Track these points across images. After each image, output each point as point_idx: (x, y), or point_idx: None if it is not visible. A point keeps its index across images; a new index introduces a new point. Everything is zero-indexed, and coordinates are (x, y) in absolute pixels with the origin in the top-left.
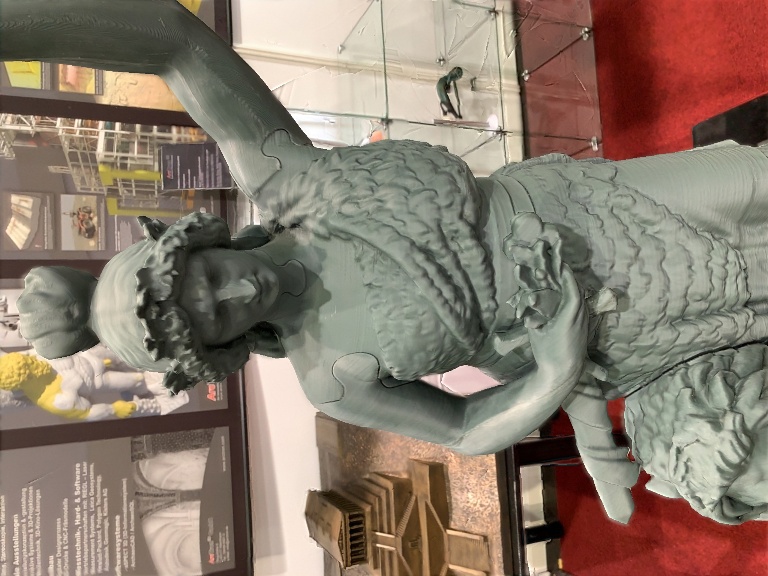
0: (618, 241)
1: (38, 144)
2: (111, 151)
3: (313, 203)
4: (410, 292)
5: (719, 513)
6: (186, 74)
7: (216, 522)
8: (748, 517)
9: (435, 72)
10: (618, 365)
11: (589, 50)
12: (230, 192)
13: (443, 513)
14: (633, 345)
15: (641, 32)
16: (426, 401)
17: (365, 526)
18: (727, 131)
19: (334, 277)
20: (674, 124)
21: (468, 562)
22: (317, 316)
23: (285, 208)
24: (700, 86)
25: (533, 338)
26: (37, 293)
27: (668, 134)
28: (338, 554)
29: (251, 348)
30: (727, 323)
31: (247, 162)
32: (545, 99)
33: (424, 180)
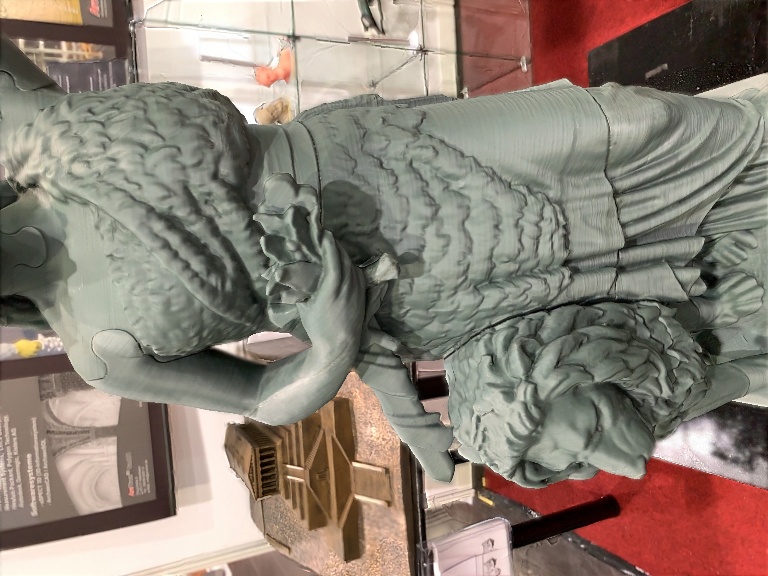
0: (413, 199)
1: None
2: None
3: (41, 161)
4: (155, 264)
5: (520, 479)
6: None
7: (134, 456)
8: (556, 479)
9: None
10: (419, 332)
11: None
12: None
13: (349, 446)
14: (432, 311)
15: None
16: (210, 374)
17: (276, 459)
18: (619, 59)
19: (77, 246)
20: None
21: (372, 492)
22: (66, 288)
23: (17, 165)
24: (626, 3)
25: (301, 312)
26: None
27: None
28: (249, 486)
29: (3, 323)
30: (537, 285)
31: None
32: (481, 13)
33: (165, 135)
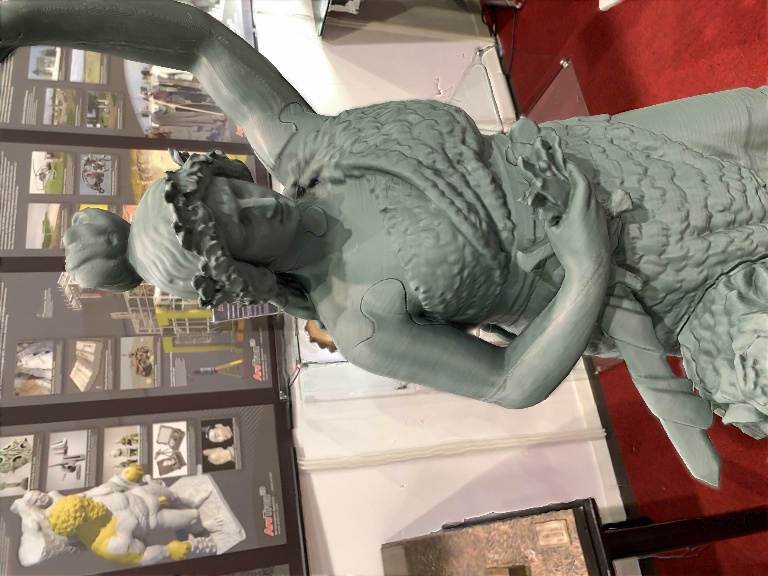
0: (623, 162)
1: (102, 295)
2: (167, 295)
3: (327, 152)
4: (424, 207)
5: None
6: (211, 59)
7: None
8: None
9: None
10: (654, 282)
11: None
12: (277, 322)
13: None
14: (664, 258)
15: None
16: (461, 339)
17: None
18: None
19: (353, 215)
20: None
21: None
22: (341, 256)
23: (304, 167)
24: None
25: (553, 238)
26: None
27: None
28: None
29: (282, 302)
30: (759, 230)
31: (267, 131)
32: None
33: (424, 115)
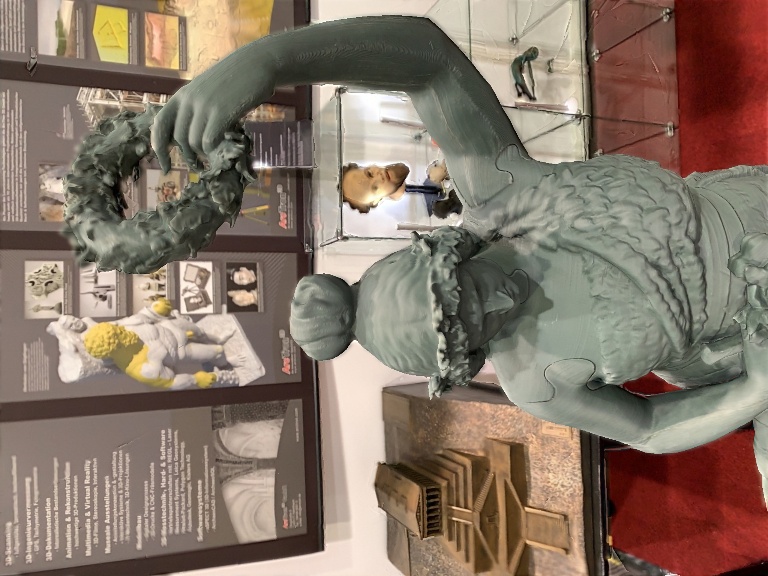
0: None
1: None
2: None
3: (544, 217)
4: (638, 305)
5: None
6: (441, 93)
7: (289, 490)
8: None
9: (507, 51)
10: None
11: (669, 32)
12: (306, 170)
13: (522, 491)
14: None
15: (729, 16)
16: (623, 403)
17: (441, 500)
18: None
19: (557, 287)
20: (761, 112)
21: (547, 539)
22: (535, 322)
23: (511, 219)
24: None
25: (749, 351)
26: (316, 300)
27: (754, 122)
28: (415, 526)
29: None
30: None
31: (480, 175)
32: (614, 80)
33: (656, 198)
